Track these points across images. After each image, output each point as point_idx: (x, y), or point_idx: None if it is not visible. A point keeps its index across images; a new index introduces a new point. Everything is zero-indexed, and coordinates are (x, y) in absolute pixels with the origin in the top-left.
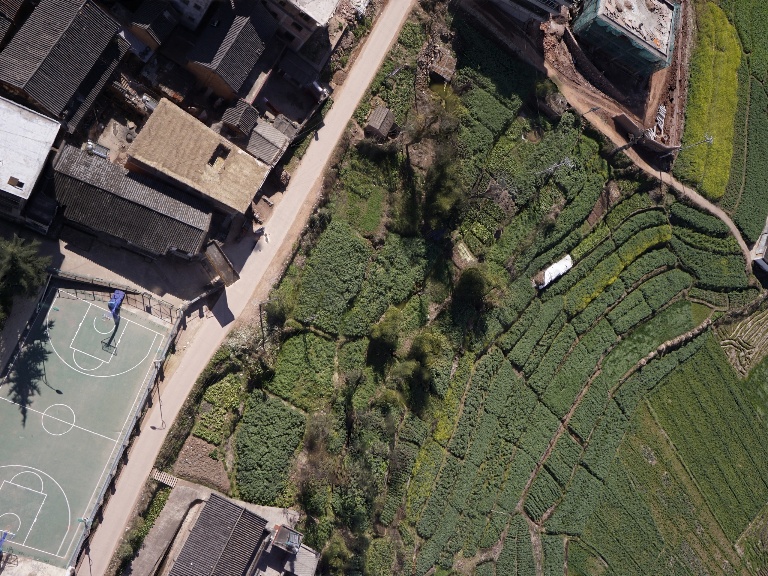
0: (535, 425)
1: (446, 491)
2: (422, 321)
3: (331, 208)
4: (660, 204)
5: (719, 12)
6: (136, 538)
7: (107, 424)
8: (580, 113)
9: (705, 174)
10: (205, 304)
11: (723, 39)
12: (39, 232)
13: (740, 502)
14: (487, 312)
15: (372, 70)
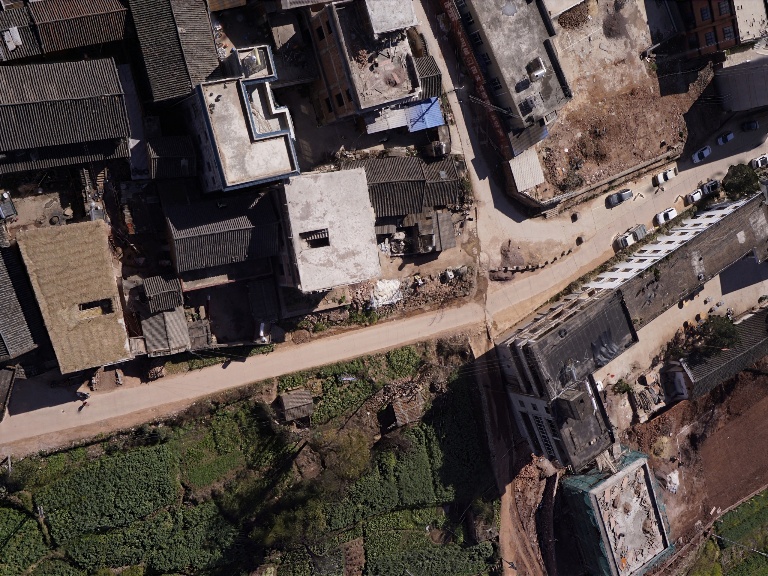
0: None
1: None
2: None
3: (177, 433)
4: None
5: None
6: None
7: None
8: (501, 555)
9: None
10: None
11: None
12: None
13: None
14: None
15: (337, 356)
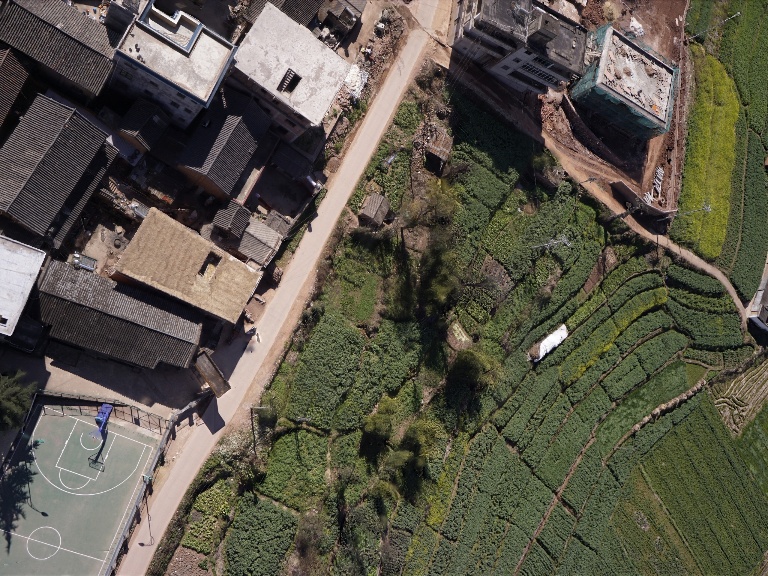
0: (529, 499)
1: (439, 575)
2: (416, 407)
3: (324, 300)
4: (656, 267)
5: (718, 66)
6: None
7: (94, 544)
8: (577, 181)
9: (702, 234)
10: (195, 411)
11: (721, 93)
12: (24, 351)
13: (732, 563)
14: (481, 390)
15: (367, 155)
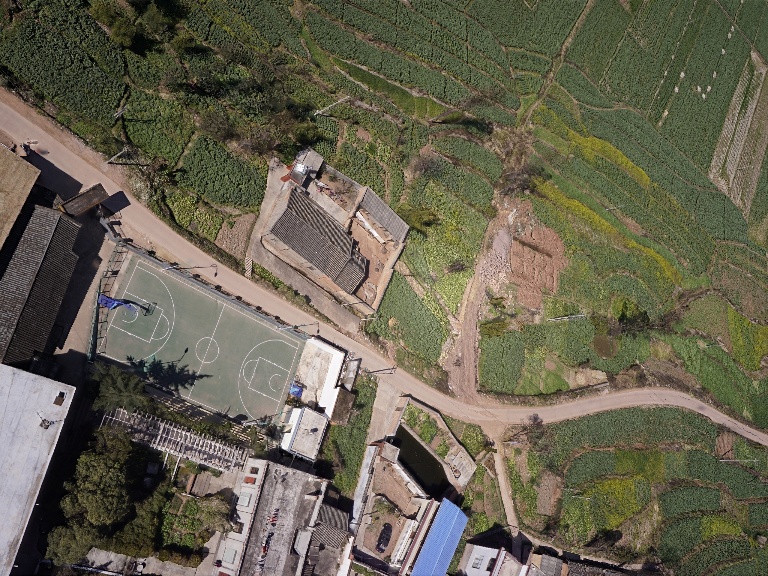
0: None
1: (247, 7)
2: None
3: None
4: None
5: None
6: (293, 292)
7: (212, 312)
8: None
9: None
10: None
11: None
12: None
13: None
14: None
15: None
